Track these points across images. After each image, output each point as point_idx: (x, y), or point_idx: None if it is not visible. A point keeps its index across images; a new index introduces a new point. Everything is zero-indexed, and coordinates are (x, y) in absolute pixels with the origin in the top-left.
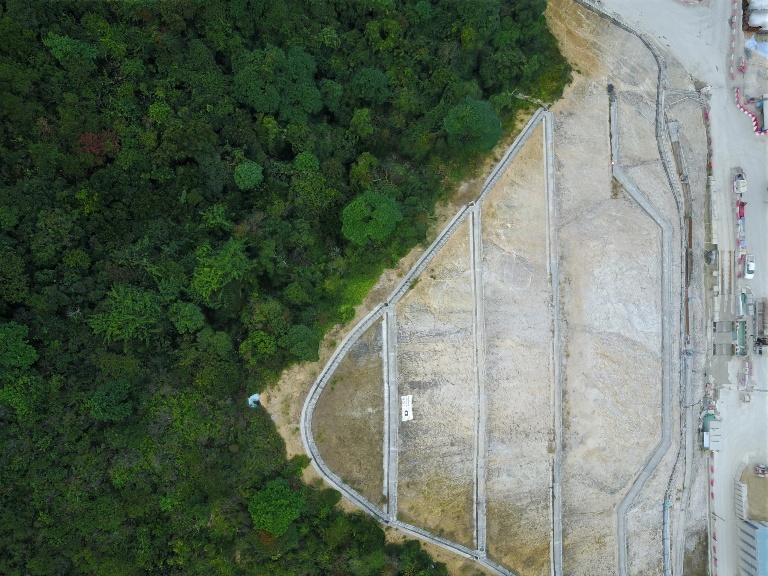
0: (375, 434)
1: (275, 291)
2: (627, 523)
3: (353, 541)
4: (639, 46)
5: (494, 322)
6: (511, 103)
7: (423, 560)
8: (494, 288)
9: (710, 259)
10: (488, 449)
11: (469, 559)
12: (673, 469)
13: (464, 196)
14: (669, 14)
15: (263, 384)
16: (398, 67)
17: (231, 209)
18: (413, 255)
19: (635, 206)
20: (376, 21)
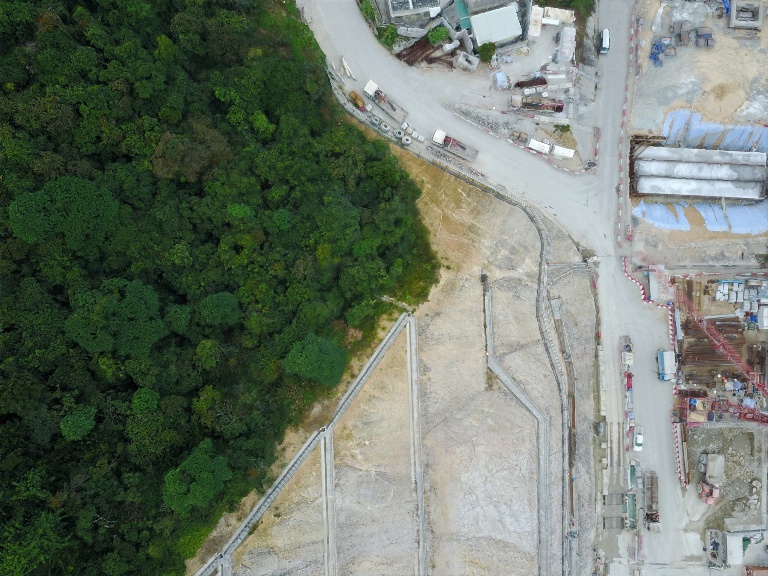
0: None
1: (97, 556)
2: None
3: None
4: (522, 220)
5: (348, 548)
6: (374, 309)
7: None
8: (349, 512)
9: (598, 431)
10: None
11: None
12: None
13: (315, 421)
14: (555, 184)
15: None
16: (253, 281)
17: (53, 469)
18: (256, 493)
19: (510, 398)
20: (229, 236)
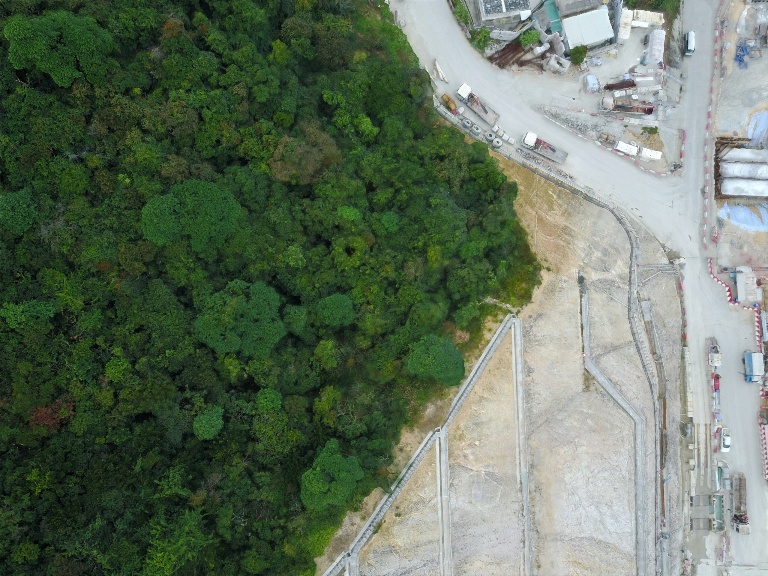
0: None
1: (233, 554)
2: None
3: None
4: (611, 222)
5: (462, 547)
6: (479, 310)
7: None
8: (462, 512)
9: (686, 433)
10: None
11: None
12: None
13: (430, 422)
14: (641, 186)
15: None
16: (364, 283)
17: (188, 468)
18: (377, 493)
19: (607, 399)
20: (342, 239)
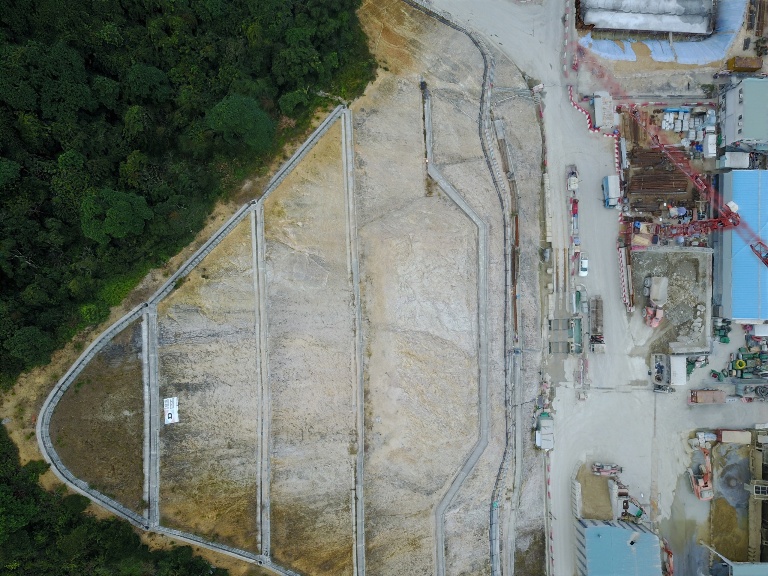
0: (133, 438)
1: (19, 292)
2: (446, 524)
3: (99, 548)
4: (467, 44)
5: (280, 322)
6: (309, 101)
7: (196, 566)
8: (281, 287)
9: (544, 257)
10: (273, 451)
11: (253, 564)
12: (500, 469)
13: (246, 194)
14: (500, 12)
15: None
16: (185, 64)
17: None
18: (184, 254)
19: (450, 204)
20: (160, 18)
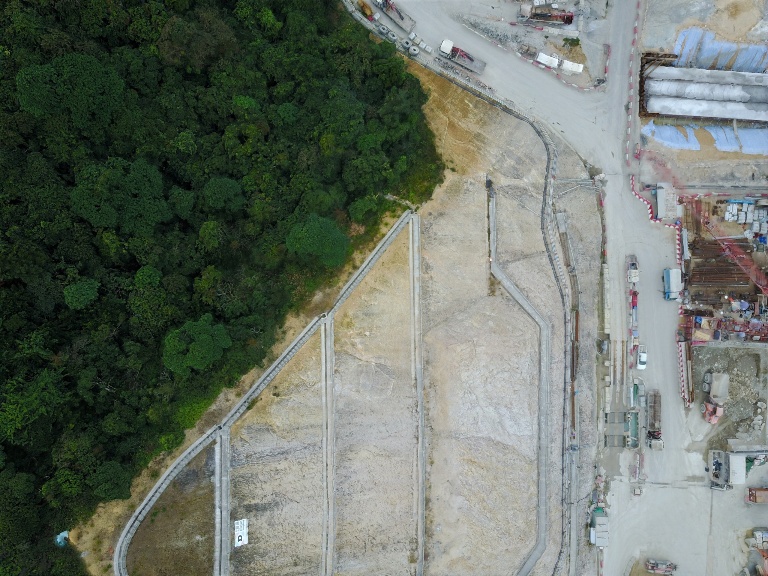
0: (204, 562)
1: (98, 418)
2: None
3: None
4: (529, 134)
5: (347, 435)
6: (377, 205)
7: None
8: (348, 400)
9: (602, 349)
10: (337, 566)
11: None
12: (554, 568)
13: (316, 307)
14: (563, 100)
15: (74, 520)
16: (257, 171)
17: (56, 333)
18: (256, 372)
19: (512, 304)
20: (234, 125)
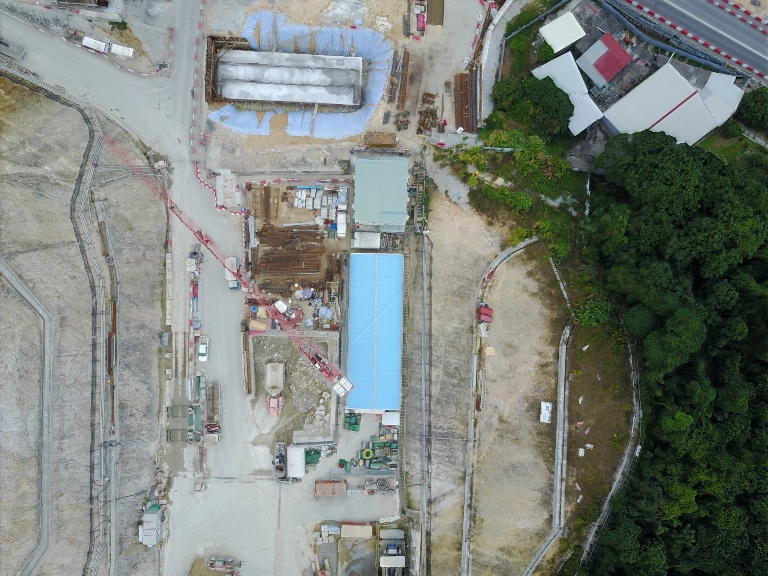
0: None
1: None
2: None
3: None
4: (73, 121)
5: None
6: None
7: None
8: None
9: (162, 341)
10: None
11: None
12: (84, 569)
13: None
14: (121, 86)
15: None
16: None
17: None
18: None
19: (13, 296)
20: None
